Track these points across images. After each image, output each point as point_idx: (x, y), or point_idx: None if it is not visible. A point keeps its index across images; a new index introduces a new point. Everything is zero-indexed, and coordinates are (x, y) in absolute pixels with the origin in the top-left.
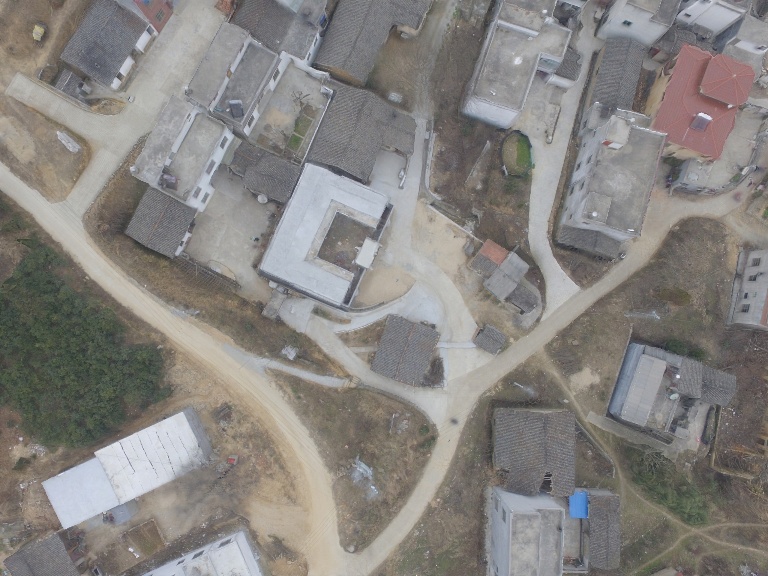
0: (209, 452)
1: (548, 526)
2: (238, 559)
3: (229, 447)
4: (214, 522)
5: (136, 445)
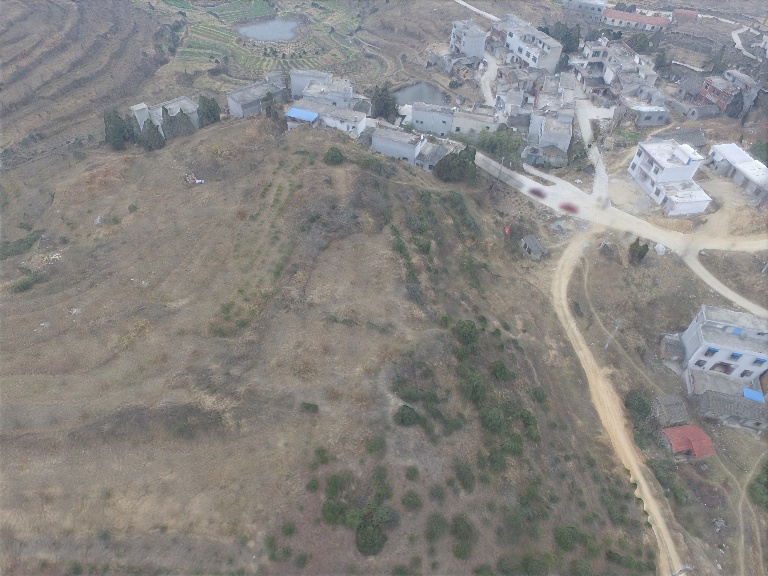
0: (761, 201)
1: (758, 349)
2: (702, 199)
3: (766, 210)
4: (713, 200)
5: (767, 172)
